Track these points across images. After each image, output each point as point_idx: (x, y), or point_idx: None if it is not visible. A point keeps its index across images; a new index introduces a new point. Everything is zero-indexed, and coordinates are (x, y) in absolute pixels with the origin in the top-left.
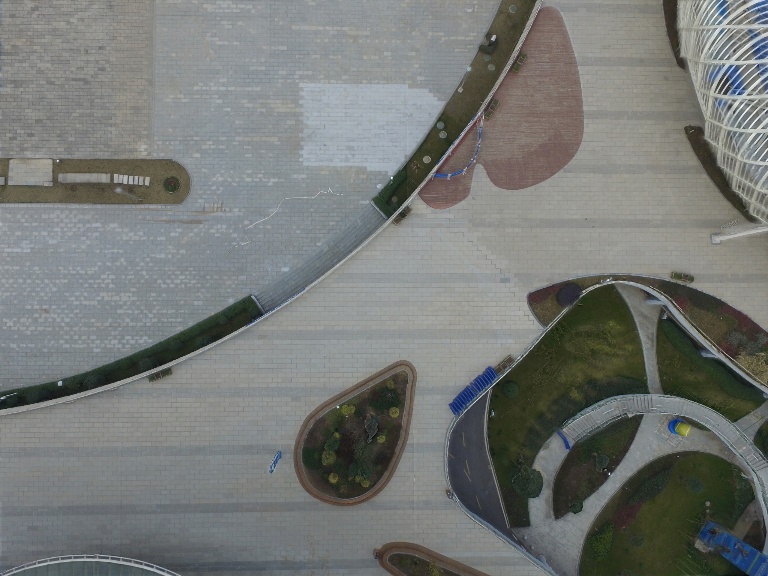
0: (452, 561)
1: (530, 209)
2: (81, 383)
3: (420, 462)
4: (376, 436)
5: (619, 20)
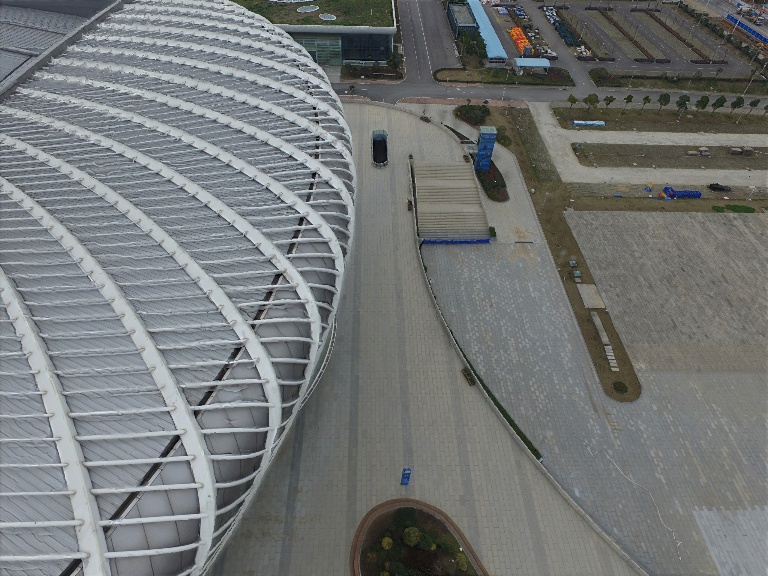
0: None
1: None
2: None
3: None
4: None
5: None
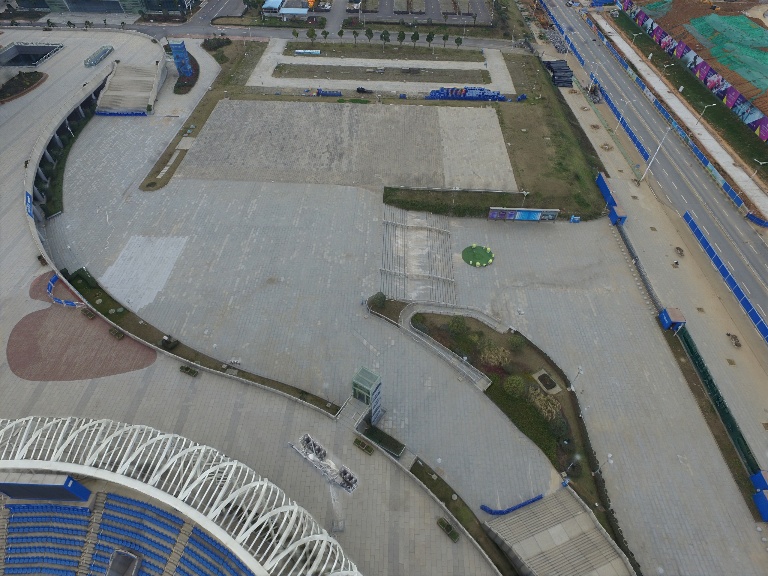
0: None
1: None
2: (63, 154)
3: None
4: None
5: (118, 417)
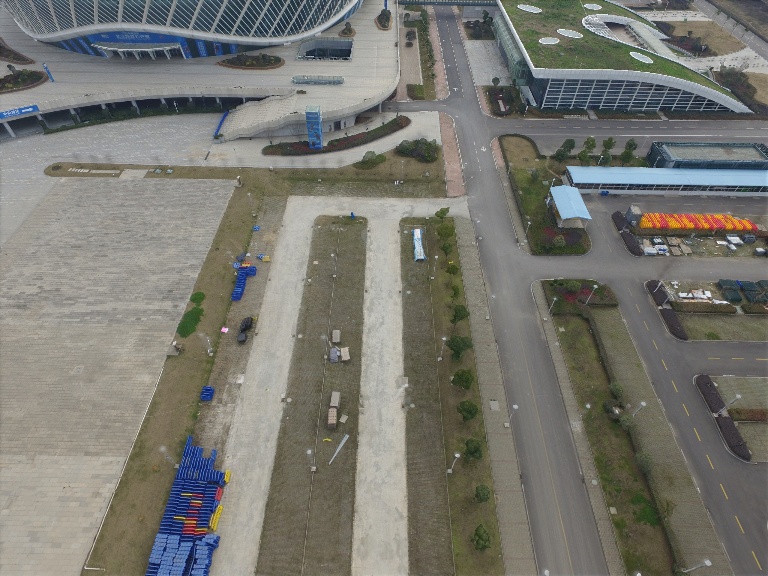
0: (5, 61)
1: None
2: None
3: None
4: (3, 79)
5: None
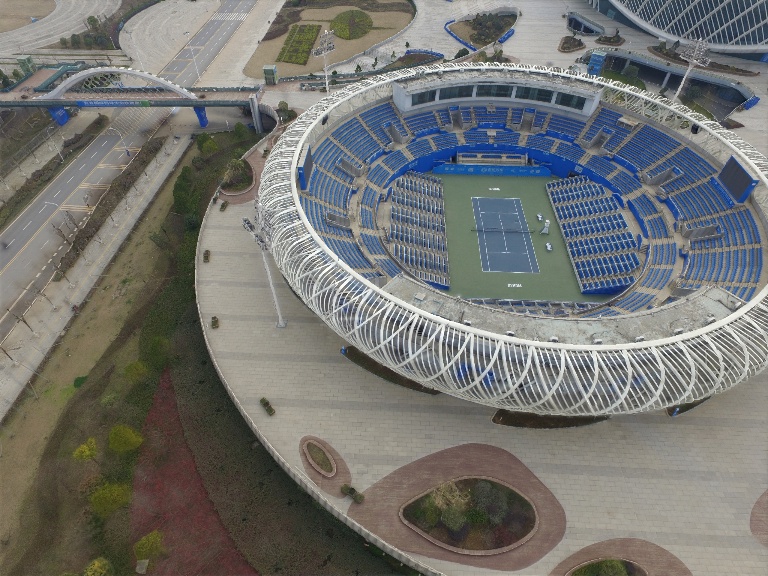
0: None
1: (766, 150)
2: None
3: (758, 91)
4: None
5: None
